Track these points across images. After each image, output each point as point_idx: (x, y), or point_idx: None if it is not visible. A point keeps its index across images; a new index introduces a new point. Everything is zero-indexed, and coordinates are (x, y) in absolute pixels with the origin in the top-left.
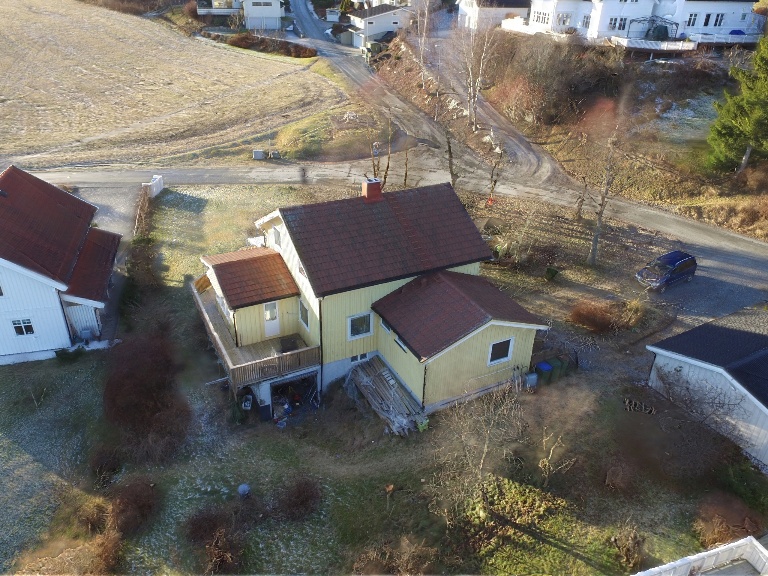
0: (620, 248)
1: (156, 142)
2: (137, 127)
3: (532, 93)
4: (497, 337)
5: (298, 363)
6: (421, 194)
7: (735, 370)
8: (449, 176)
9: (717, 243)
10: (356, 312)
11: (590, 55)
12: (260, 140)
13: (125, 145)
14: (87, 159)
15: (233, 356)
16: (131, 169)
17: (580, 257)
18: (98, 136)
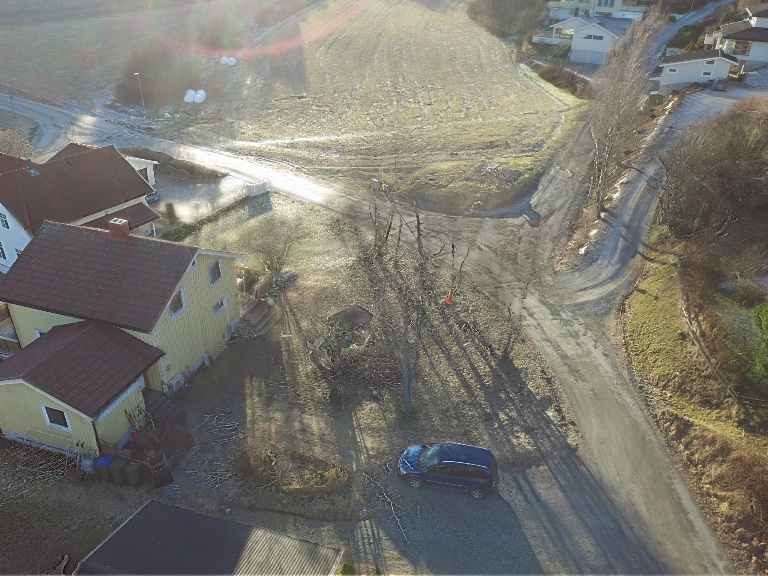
0: (481, 414)
1: (334, 153)
2: (344, 137)
3: (668, 190)
4: (47, 401)
5: (8, 348)
6: (161, 249)
7: (90, 573)
8: (484, 259)
9: (621, 481)
10: (42, 327)
11: (764, 157)
12: (399, 171)
13: (312, 150)
14: (273, 154)
15: (7, 324)
16: (281, 170)
17: (416, 398)
18: (310, 138)
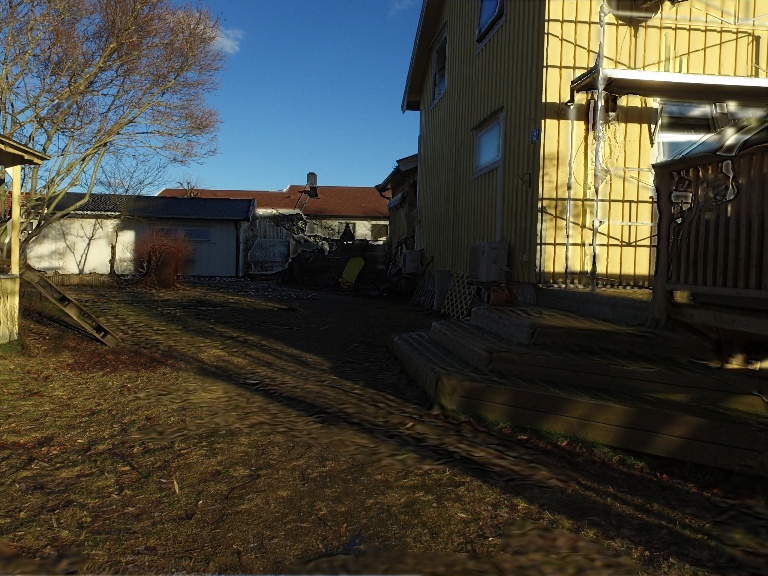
0: None
1: None
2: None
3: None
4: None
5: None
6: None
7: None
8: None
9: None
10: None
11: None
12: None
13: None
14: None
15: None
16: None
17: None
18: None
